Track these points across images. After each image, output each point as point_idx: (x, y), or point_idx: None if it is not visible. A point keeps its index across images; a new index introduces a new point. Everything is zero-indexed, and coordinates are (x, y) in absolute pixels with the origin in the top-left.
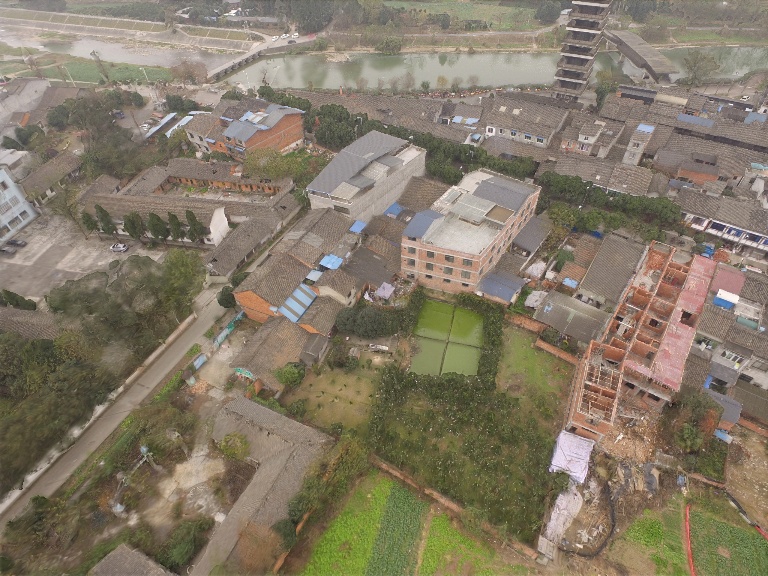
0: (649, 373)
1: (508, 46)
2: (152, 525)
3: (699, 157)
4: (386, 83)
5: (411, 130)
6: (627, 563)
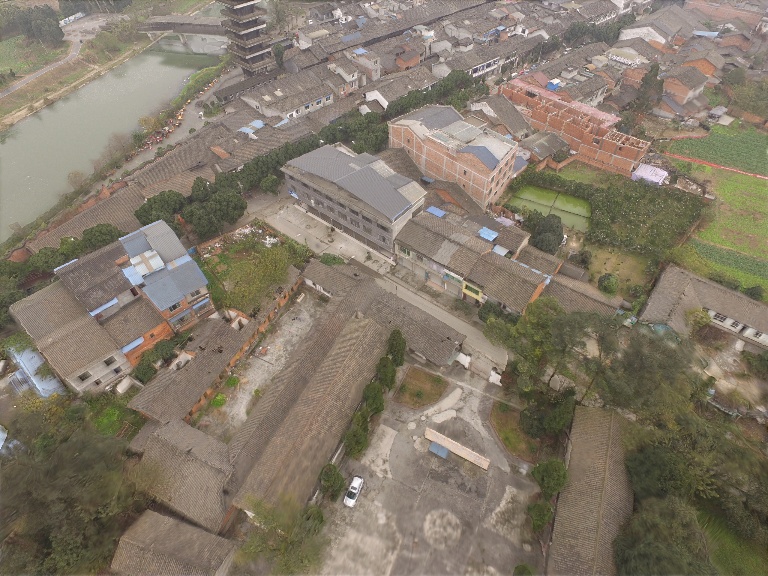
0: (610, 122)
1: (72, 79)
2: (762, 395)
3: (396, 52)
4: (102, 160)
5: (274, 151)
6: (703, 179)
